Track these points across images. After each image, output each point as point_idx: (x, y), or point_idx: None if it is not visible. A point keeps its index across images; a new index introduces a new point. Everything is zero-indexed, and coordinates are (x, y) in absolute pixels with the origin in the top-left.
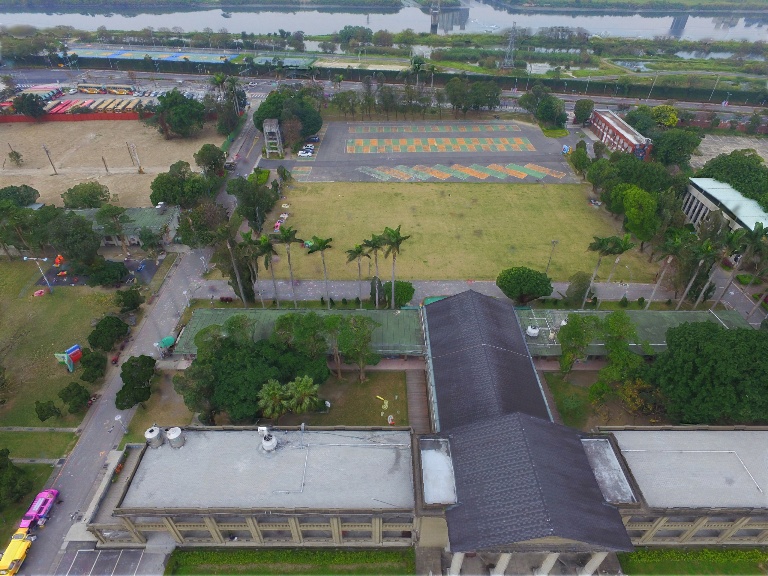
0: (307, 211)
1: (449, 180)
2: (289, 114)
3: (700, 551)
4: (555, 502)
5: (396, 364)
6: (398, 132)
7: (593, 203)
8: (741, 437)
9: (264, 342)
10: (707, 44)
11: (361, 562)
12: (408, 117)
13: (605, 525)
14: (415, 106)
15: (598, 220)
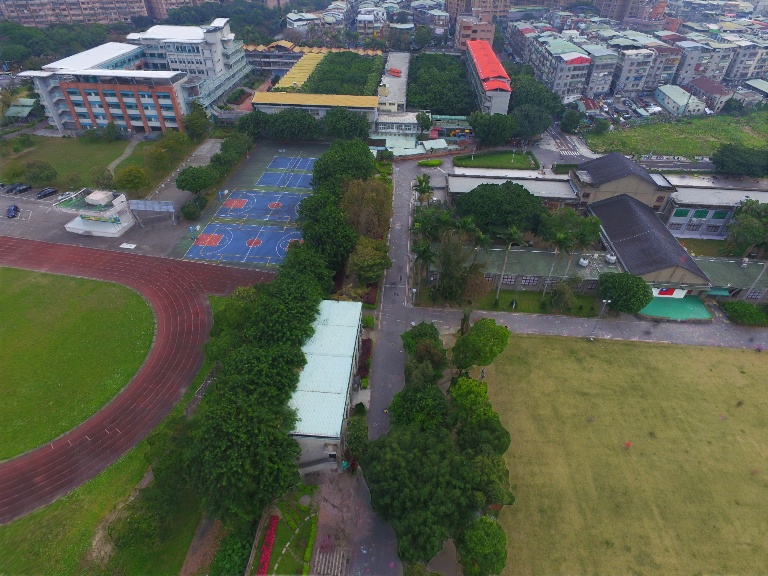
0: None
1: None
2: None
3: None
4: None
5: None
6: None
7: None
8: None
9: None
10: None
11: None
12: None
13: None
14: None
15: None
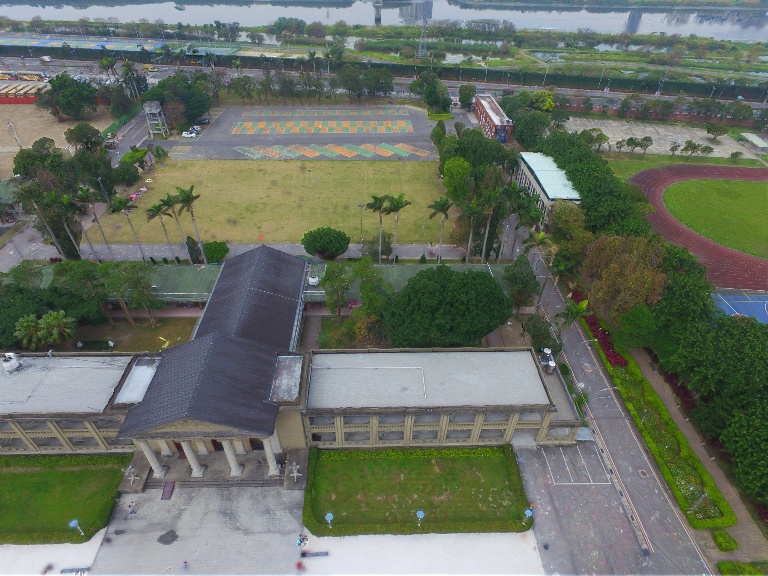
0: (168, 185)
1: (317, 158)
2: (170, 96)
3: (384, 451)
4: (207, 395)
5: (191, 312)
6: (290, 116)
7: (442, 177)
8: (436, 357)
9: (48, 288)
10: (611, 36)
11: (83, 464)
12: (305, 102)
13: (253, 415)
14: (310, 91)
15: (439, 192)
